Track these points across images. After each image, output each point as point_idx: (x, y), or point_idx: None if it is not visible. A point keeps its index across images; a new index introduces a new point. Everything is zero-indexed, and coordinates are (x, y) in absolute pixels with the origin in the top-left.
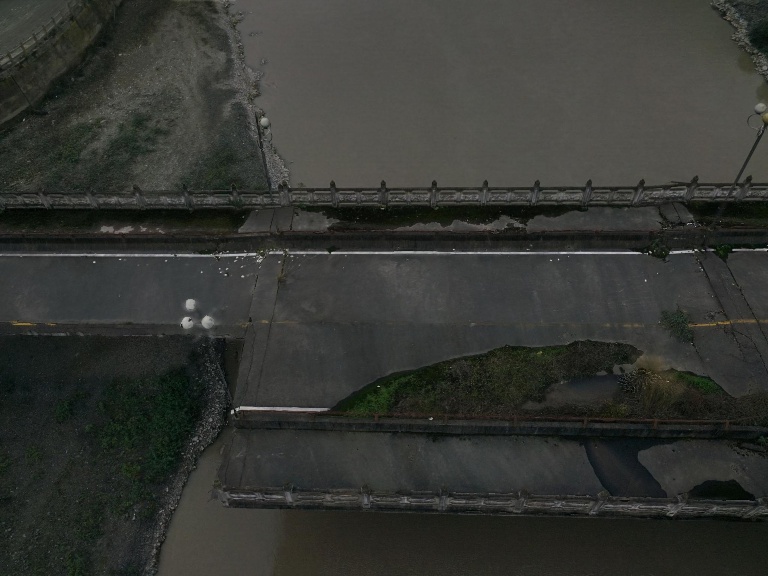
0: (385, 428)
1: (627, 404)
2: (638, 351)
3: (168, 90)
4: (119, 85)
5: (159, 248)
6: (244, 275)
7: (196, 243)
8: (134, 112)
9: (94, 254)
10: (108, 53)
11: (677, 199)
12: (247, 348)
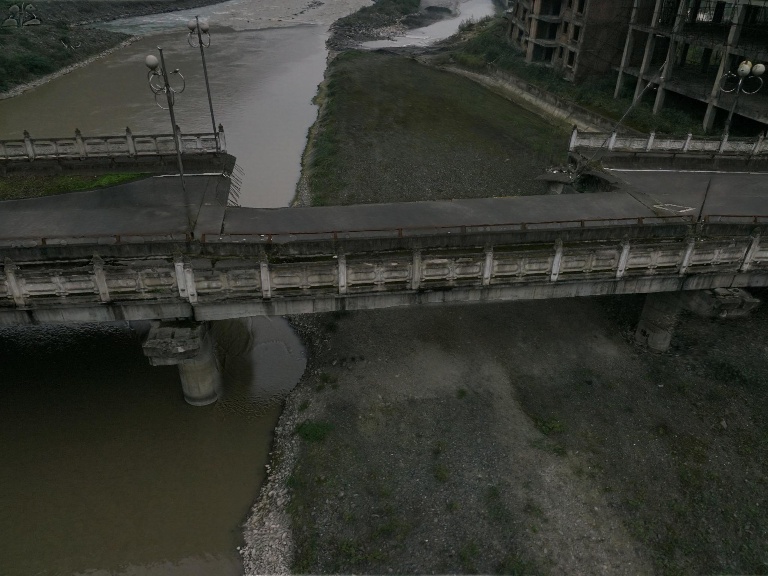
0: None
1: None
2: None
3: None
4: None
5: None
6: None
7: None
8: None
9: None
10: None
11: None
12: (223, 196)
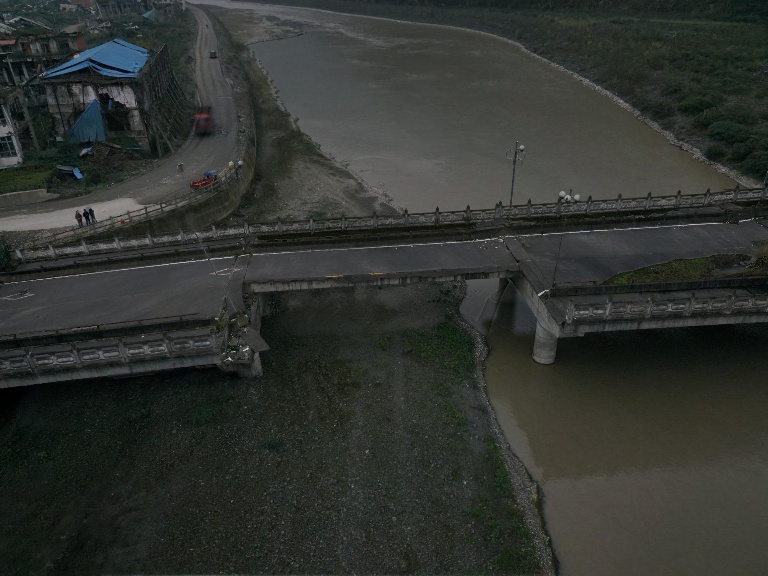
0: (635, 289)
1: None
2: (749, 256)
3: (327, 199)
4: (287, 199)
5: (433, 240)
6: (497, 247)
7: (457, 236)
8: (311, 211)
9: (393, 246)
10: (266, 183)
11: (729, 201)
12: (527, 271)
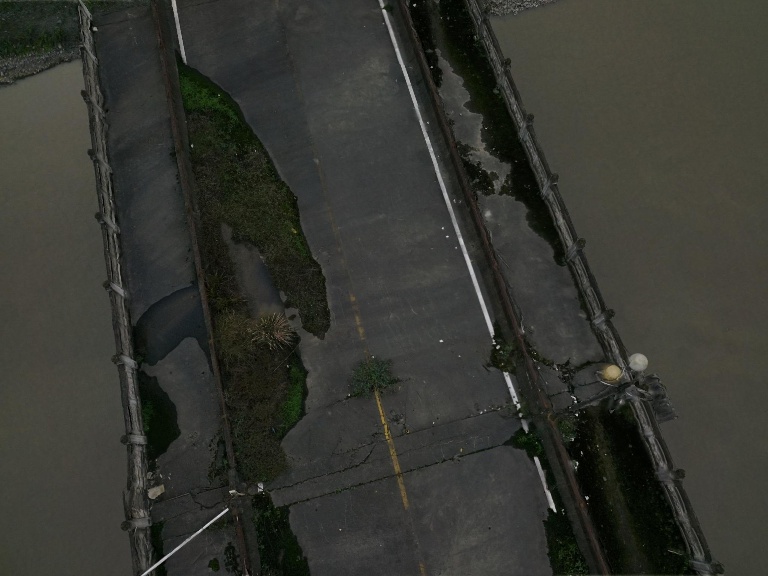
0: None
1: (237, 317)
2: (322, 333)
3: None
4: None
5: None
6: None
7: None
8: None
9: None
10: None
11: None
12: None
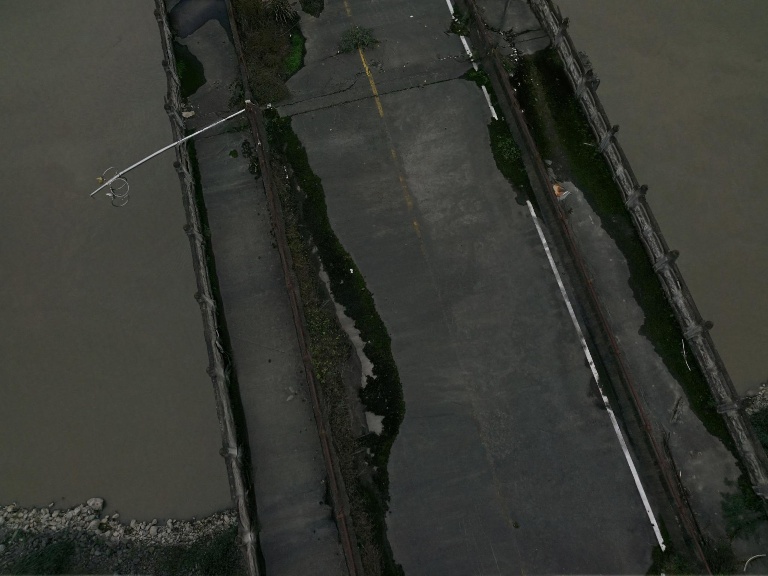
0: None
1: None
2: (318, 13)
3: None
4: None
5: None
6: None
7: None
8: None
9: None
10: None
11: None
12: None
